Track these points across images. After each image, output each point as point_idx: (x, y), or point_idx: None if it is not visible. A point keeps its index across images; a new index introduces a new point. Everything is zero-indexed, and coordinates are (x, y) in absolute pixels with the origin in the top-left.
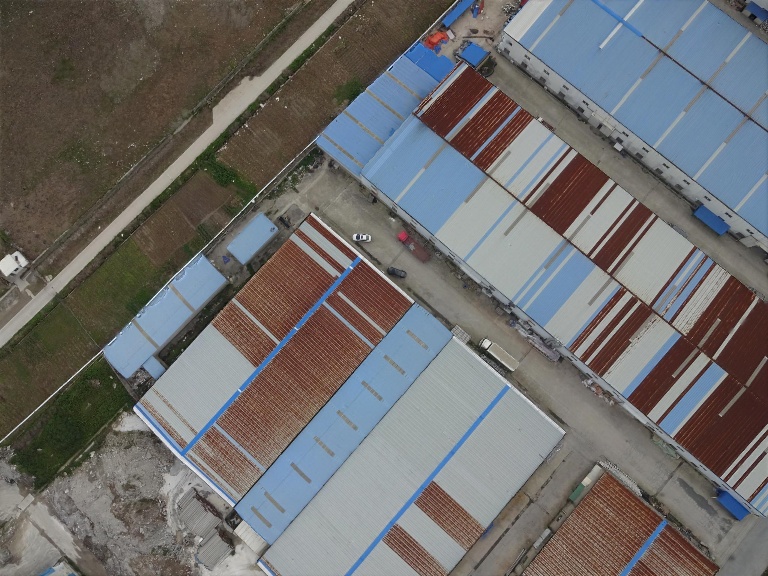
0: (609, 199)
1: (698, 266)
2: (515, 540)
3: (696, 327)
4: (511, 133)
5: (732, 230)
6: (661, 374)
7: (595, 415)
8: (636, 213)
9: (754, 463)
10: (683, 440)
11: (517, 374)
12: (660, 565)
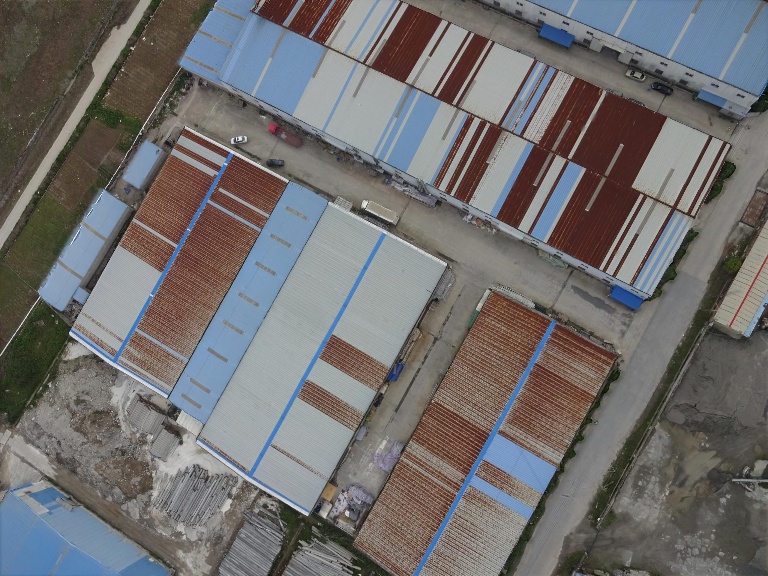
0: (445, 38)
1: (541, 77)
2: (428, 377)
3: (547, 133)
4: (343, 4)
5: (578, 39)
6: (522, 186)
7: (481, 246)
8: (473, 44)
9: (629, 247)
10: (556, 243)
11: (401, 227)
12: (557, 364)
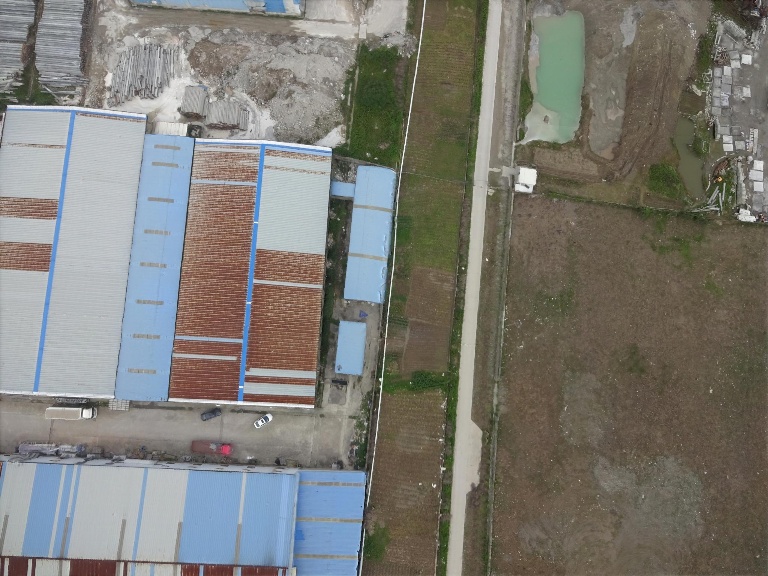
0: None
1: None
2: None
3: None
4: None
5: None
6: None
7: None
8: None
9: None
10: None
11: None
12: None
